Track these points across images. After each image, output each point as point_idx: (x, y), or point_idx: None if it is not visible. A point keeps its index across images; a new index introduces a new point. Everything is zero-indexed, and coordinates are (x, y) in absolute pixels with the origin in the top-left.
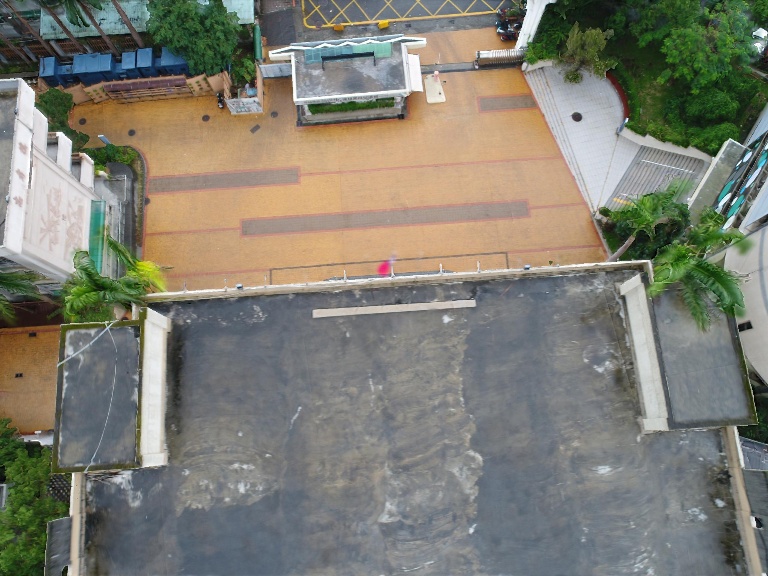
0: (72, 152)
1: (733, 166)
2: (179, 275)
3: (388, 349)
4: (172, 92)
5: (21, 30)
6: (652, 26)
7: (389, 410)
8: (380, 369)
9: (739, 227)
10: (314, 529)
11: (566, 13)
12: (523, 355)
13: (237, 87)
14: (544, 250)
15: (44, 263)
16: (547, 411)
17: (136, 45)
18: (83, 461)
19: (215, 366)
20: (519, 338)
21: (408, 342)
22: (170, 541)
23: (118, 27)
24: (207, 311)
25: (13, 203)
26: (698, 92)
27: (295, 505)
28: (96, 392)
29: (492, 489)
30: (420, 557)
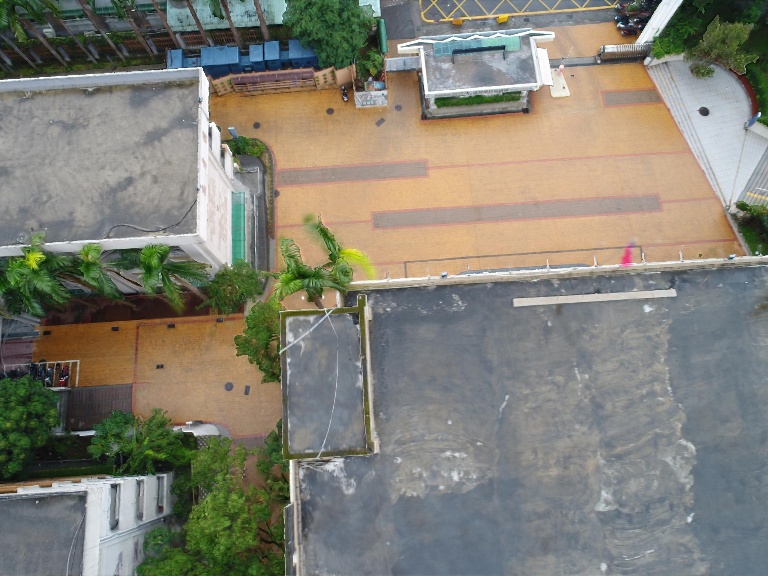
0: None
1: None
2: None
3: (591, 338)
4: (296, 85)
5: (140, 23)
6: None
7: (597, 399)
8: (585, 358)
9: None
10: (531, 517)
11: (697, 7)
12: (727, 345)
13: (360, 80)
14: (678, 244)
15: (207, 253)
16: (756, 401)
17: (258, 38)
18: (313, 447)
19: (419, 354)
20: (722, 328)
21: (611, 331)
22: (387, 529)
23: (245, 20)
24: (406, 300)
25: (201, 191)
26: None
27: (510, 493)
28: (320, 379)
29: (707, 478)
30: (640, 546)
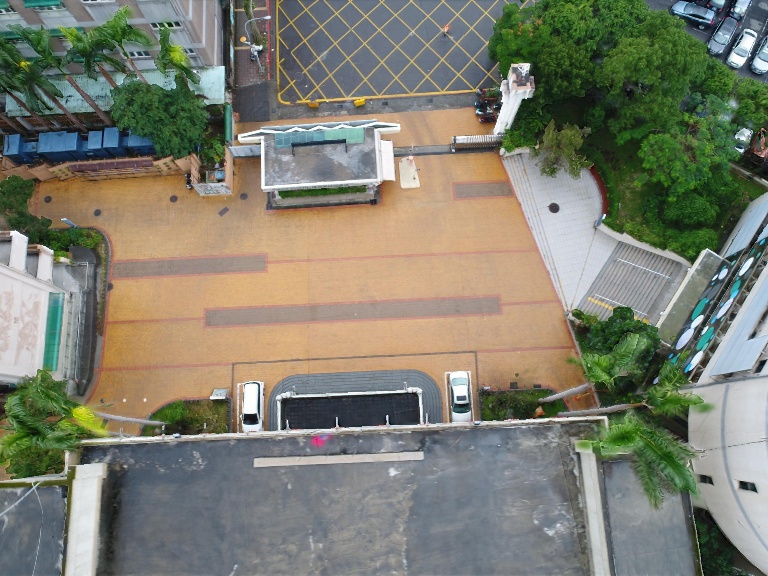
0: (32, 239)
1: (709, 279)
2: (139, 367)
3: (330, 503)
4: (140, 171)
5: None
6: (631, 125)
7: (328, 571)
8: (321, 525)
9: (707, 365)
10: None
11: None
12: (471, 514)
13: (207, 166)
14: (515, 350)
15: None
16: None
17: None
18: None
19: (150, 517)
20: (467, 495)
21: (352, 496)
22: None
23: (85, 105)
24: (145, 456)
25: None
26: (675, 200)
27: None
28: (19, 558)
29: None
30: None
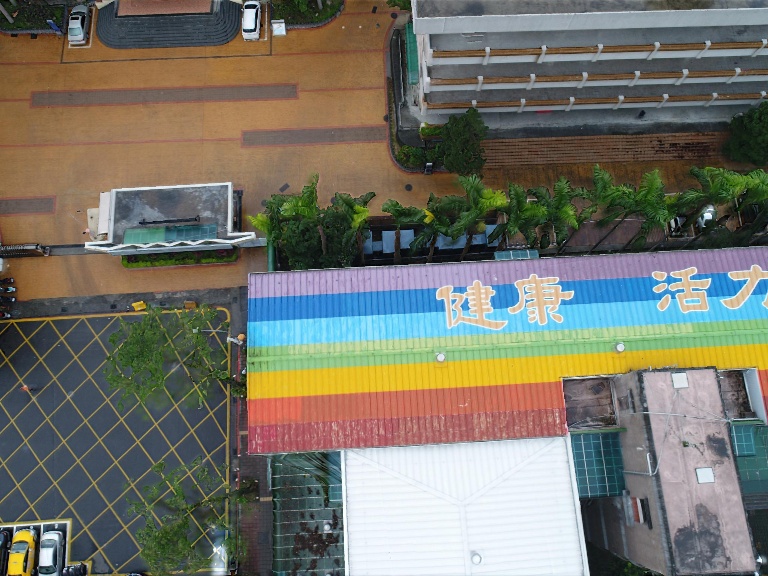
0: None
1: None
2: (351, 52)
3: None
4: None
5: None
6: None
7: None
8: None
9: None
10: None
11: None
12: None
13: None
14: (27, 63)
15: None
16: None
17: None
18: None
19: None
20: None
21: None
22: None
23: None
24: None
25: None
26: None
27: None
28: None
29: None
30: None
